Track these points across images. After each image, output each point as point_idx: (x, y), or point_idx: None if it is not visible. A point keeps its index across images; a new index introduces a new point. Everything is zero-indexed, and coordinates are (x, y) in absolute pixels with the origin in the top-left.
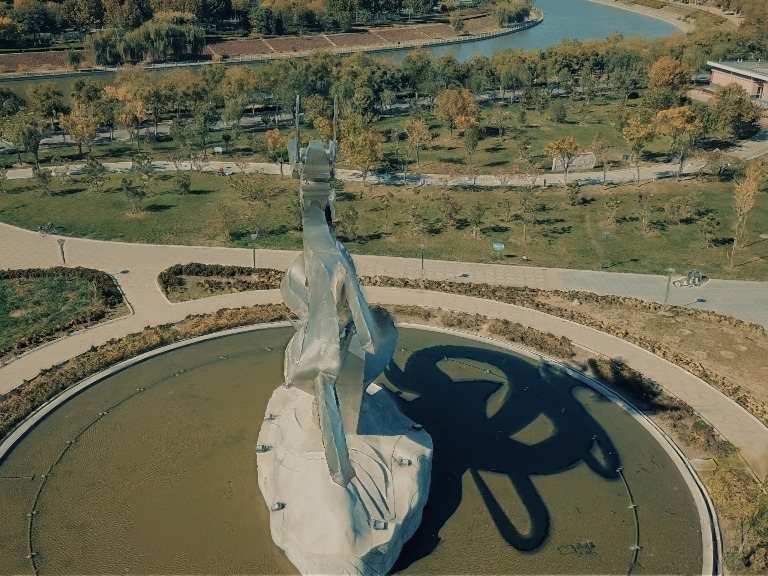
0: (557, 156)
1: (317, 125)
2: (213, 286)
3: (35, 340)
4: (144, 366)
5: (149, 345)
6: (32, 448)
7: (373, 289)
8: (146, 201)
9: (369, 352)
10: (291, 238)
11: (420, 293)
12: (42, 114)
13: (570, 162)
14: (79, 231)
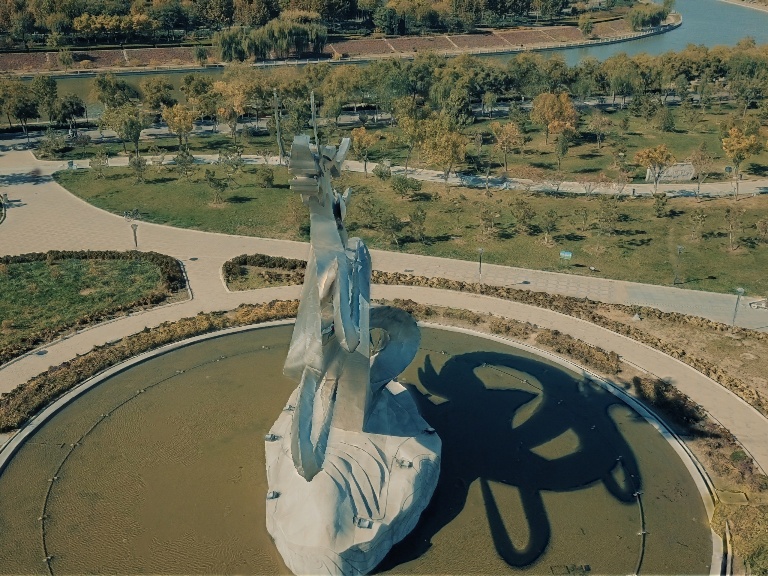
0: (648, 165)
1: (401, 125)
2: (272, 278)
3: (96, 318)
4: (189, 350)
5: (197, 330)
6: (69, 418)
7: (428, 290)
8: (229, 192)
9: (346, 349)
10: (359, 235)
11: (475, 297)
12: (150, 106)
13: (661, 172)
14: (161, 218)
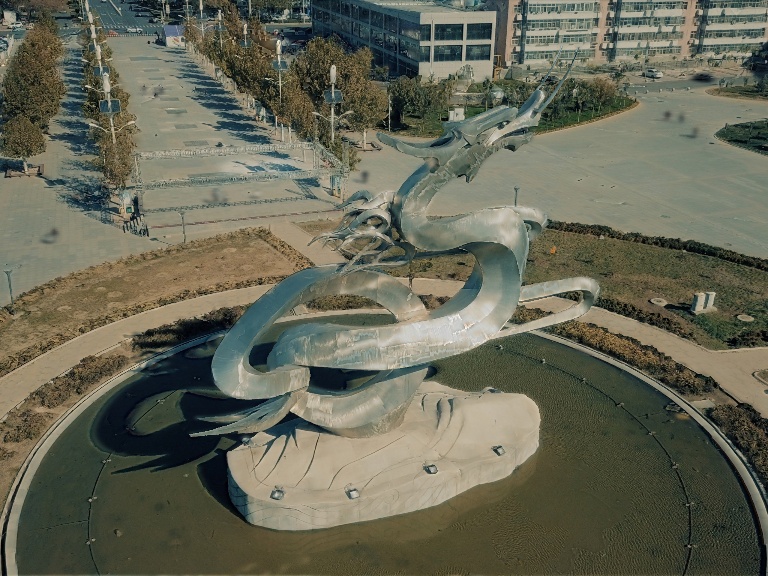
0: None
1: None
2: None
3: None
4: None
5: None
6: None
7: None
8: None
9: None
10: None
11: None
12: None
13: None
14: None
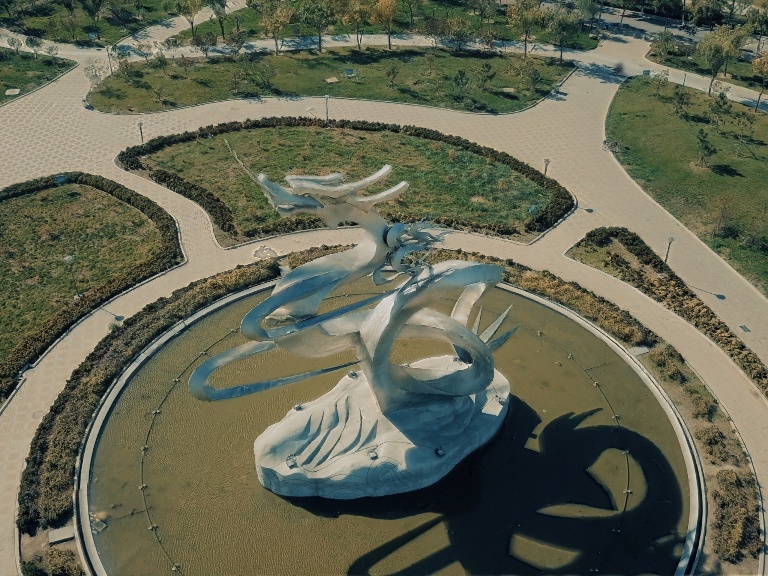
0: None
1: None
2: (613, 262)
3: (449, 223)
4: None
5: None
6: None
7: (723, 358)
8: (728, 159)
9: None
10: None
11: (753, 394)
12: None
13: None
14: (631, 159)
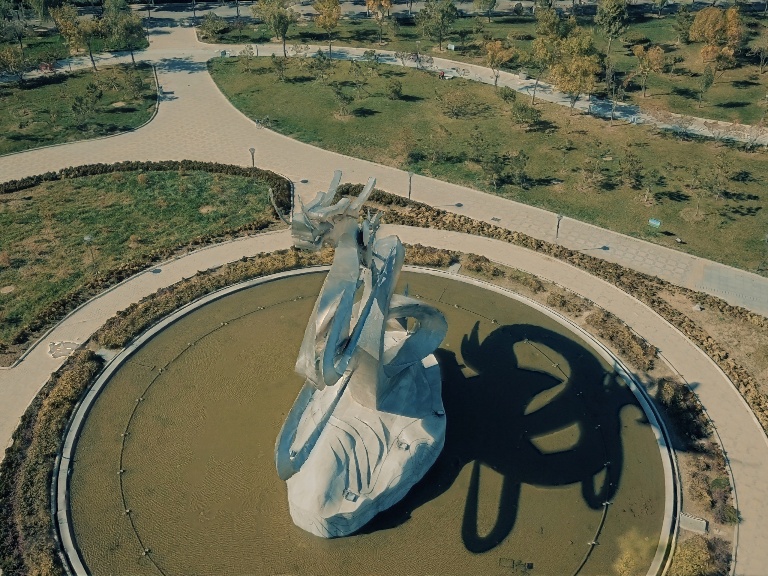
0: None
1: (535, 46)
2: None
3: (207, 240)
4: (275, 285)
5: (285, 266)
6: (164, 342)
7: (506, 246)
8: (357, 103)
9: None
10: (463, 170)
11: (547, 260)
12: None
13: None
14: (288, 128)
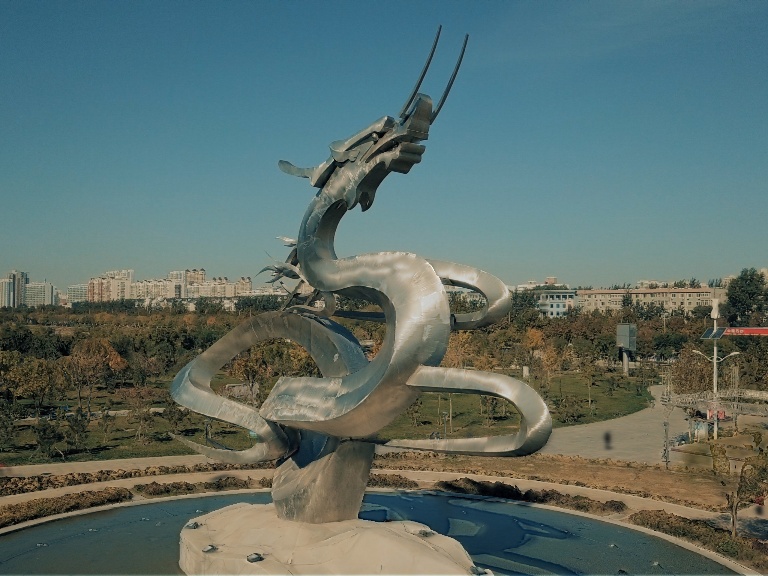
0: (241, 376)
1: None
2: None
3: None
4: None
5: None
6: None
7: (155, 478)
8: None
9: (493, 316)
10: None
11: (211, 474)
12: None
13: (254, 381)
14: None
